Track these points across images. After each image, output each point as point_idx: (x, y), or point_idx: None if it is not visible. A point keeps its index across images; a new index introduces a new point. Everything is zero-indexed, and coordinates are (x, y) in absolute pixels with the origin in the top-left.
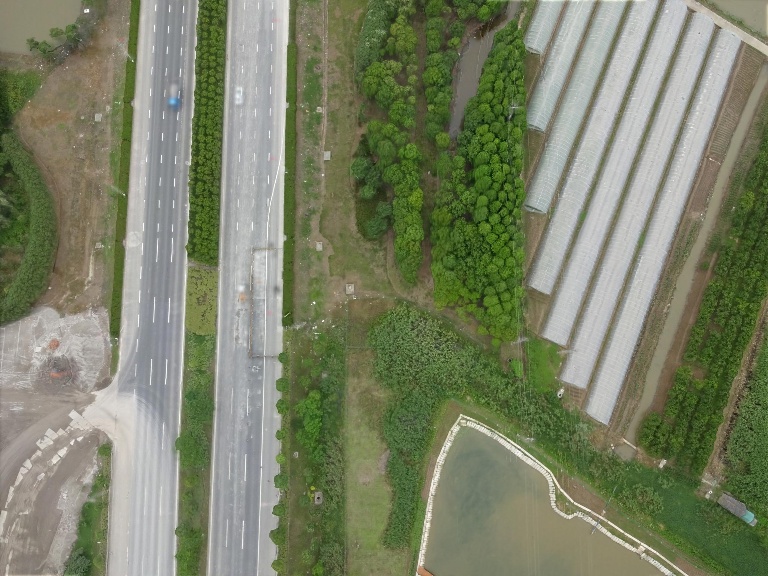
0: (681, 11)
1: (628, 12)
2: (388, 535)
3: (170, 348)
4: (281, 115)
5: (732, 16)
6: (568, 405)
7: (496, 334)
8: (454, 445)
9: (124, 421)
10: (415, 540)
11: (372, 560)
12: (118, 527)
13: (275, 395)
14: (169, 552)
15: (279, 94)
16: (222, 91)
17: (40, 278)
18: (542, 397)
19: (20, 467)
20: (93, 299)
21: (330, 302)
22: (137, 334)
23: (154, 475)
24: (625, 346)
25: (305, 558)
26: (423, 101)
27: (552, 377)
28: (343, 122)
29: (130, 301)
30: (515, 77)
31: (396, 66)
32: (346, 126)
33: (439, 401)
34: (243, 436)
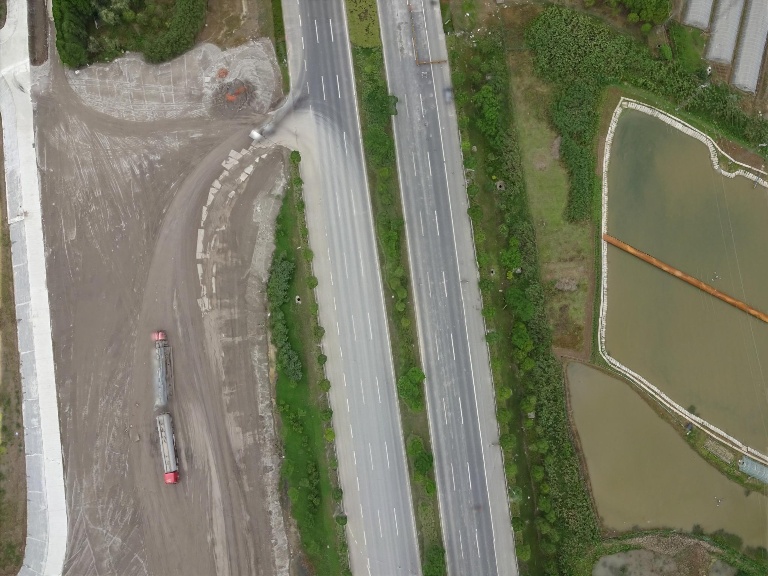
0: None
1: None
2: (572, 209)
3: (338, 64)
4: None
5: None
6: (716, 80)
7: (648, 17)
8: (619, 126)
9: (305, 135)
10: (596, 211)
11: (559, 235)
12: (316, 231)
13: (447, 96)
14: (369, 247)
15: None
16: None
17: (200, 10)
18: (693, 75)
19: (210, 188)
20: (251, 32)
21: (482, 12)
22: (304, 55)
23: (343, 180)
24: (762, 21)
25: (503, 230)
26: None
27: (698, 58)
28: None
29: (291, 26)
30: None
31: None
32: None
33: (599, 89)
34: (422, 136)
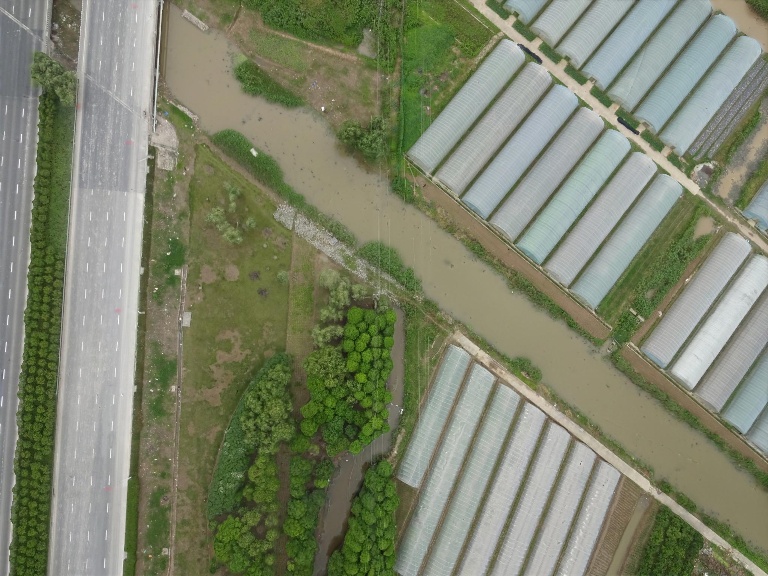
0: (564, 439)
1: (511, 438)
2: None
3: None
4: (118, 566)
5: (614, 441)
6: None
7: None
8: None
9: None
10: None
11: None
12: None
13: None
14: None
15: (116, 540)
16: (44, 546)
17: None
18: None
19: None
20: None
21: None
22: None
23: None
24: None
25: None
26: (285, 541)
27: None
28: (192, 567)
29: None
30: (383, 549)
31: (253, 521)
32: (196, 572)
33: None
34: None
